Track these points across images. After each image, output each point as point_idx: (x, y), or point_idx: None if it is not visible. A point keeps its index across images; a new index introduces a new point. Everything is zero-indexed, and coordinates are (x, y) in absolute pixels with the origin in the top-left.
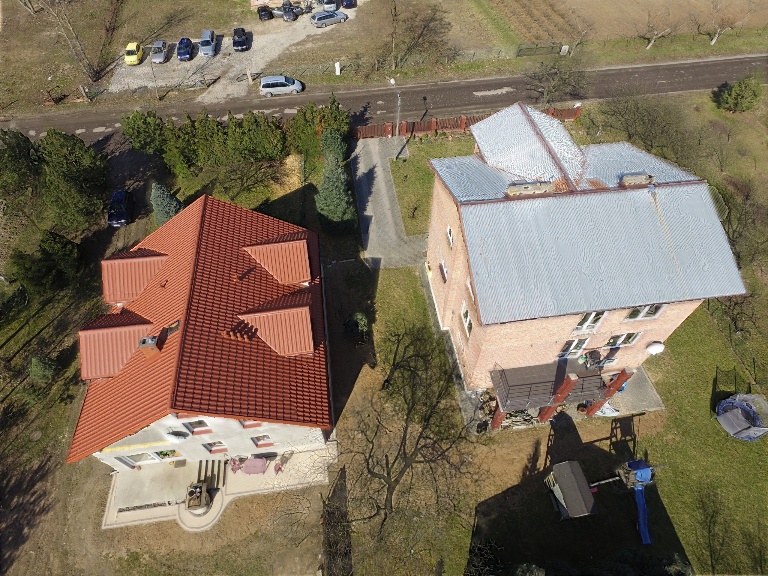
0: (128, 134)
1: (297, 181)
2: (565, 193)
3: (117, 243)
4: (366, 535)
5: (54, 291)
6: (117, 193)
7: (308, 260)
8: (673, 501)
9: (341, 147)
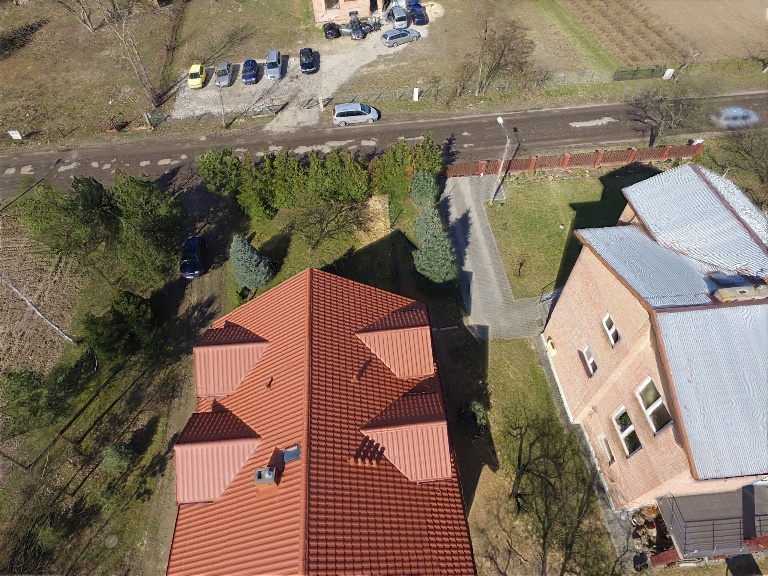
0: (203, 175)
1: (383, 227)
2: None
3: (190, 298)
4: None
5: (125, 356)
6: (189, 240)
7: (431, 351)
8: None
9: (433, 190)
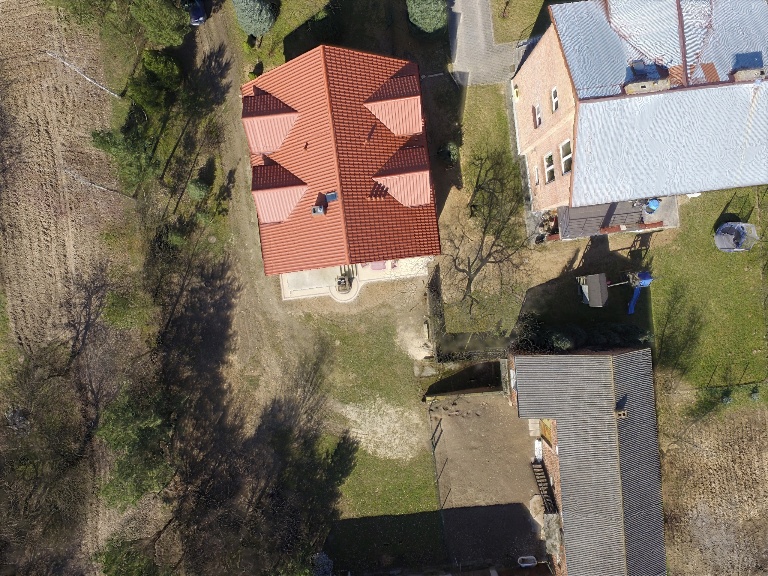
0: None
1: None
2: (676, 89)
3: (203, 47)
4: (454, 306)
5: (167, 108)
6: None
7: None
8: (658, 289)
9: None
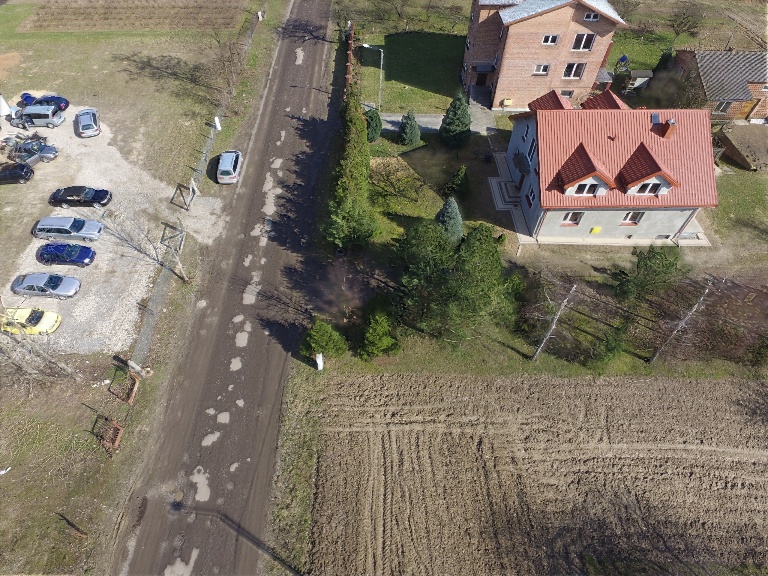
0: None
1: (396, 161)
2: None
3: None
4: None
5: None
6: None
7: None
8: None
9: None
